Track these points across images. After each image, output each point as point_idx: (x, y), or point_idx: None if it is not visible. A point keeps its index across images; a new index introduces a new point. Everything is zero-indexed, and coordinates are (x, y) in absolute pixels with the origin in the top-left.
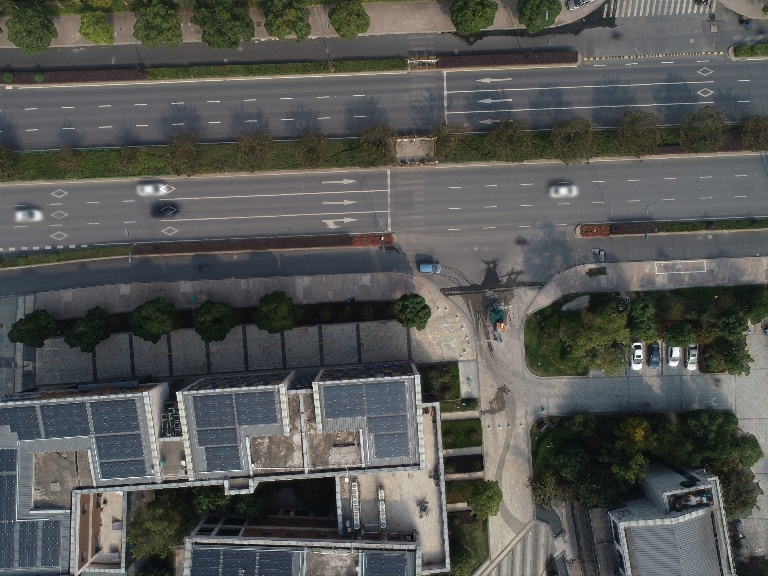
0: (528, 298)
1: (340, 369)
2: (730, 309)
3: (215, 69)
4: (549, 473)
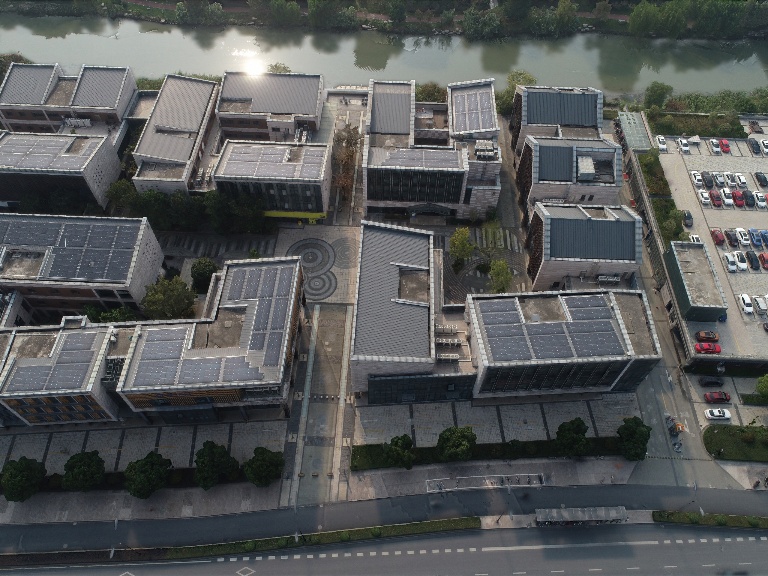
0: None
1: None
2: None
3: None
4: None
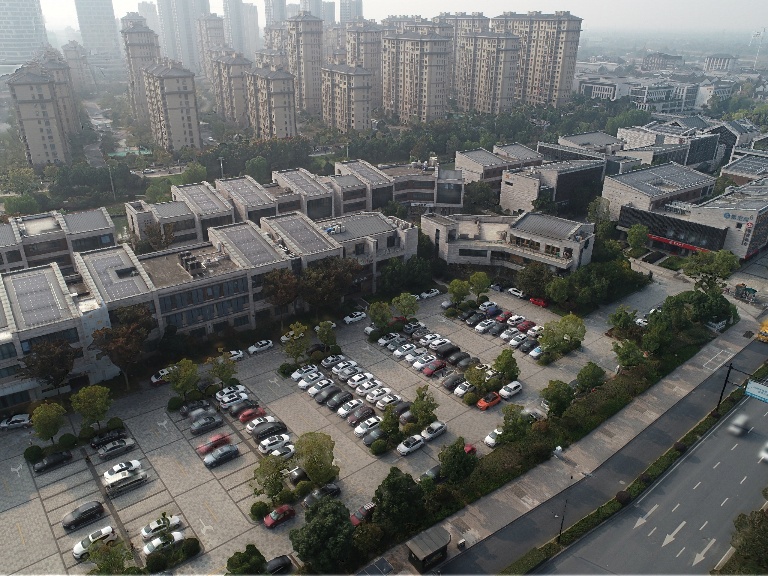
0: (750, 311)
1: None
2: (672, 330)
3: None
4: None
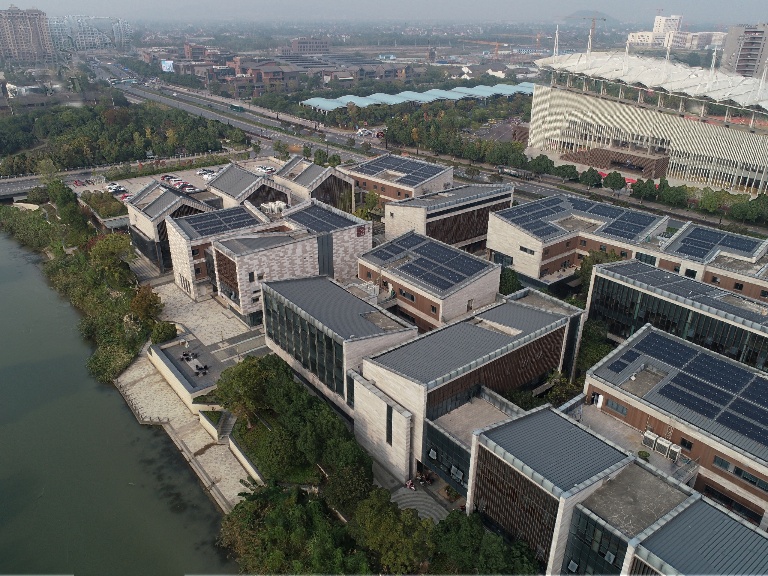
0: None
1: None
2: None
3: (765, 236)
4: None
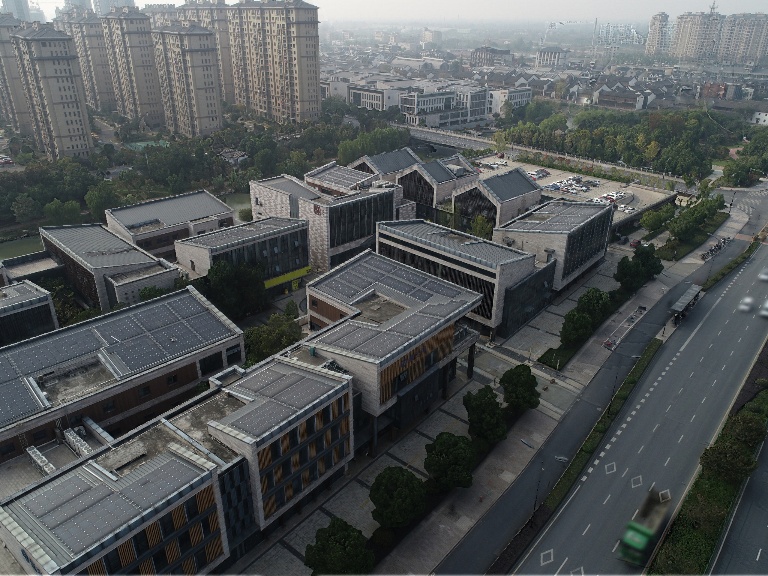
0: None
1: (203, 569)
2: None
3: None
4: None
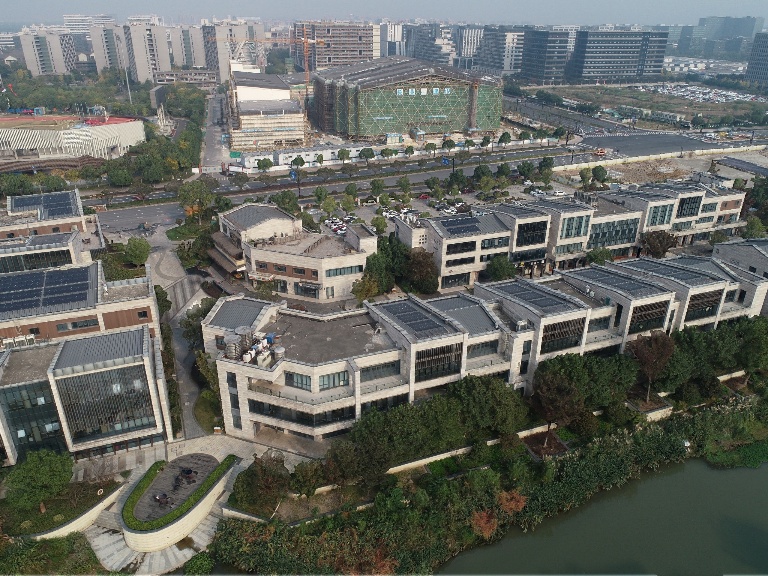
0: None
1: None
2: None
3: None
4: (192, 258)
